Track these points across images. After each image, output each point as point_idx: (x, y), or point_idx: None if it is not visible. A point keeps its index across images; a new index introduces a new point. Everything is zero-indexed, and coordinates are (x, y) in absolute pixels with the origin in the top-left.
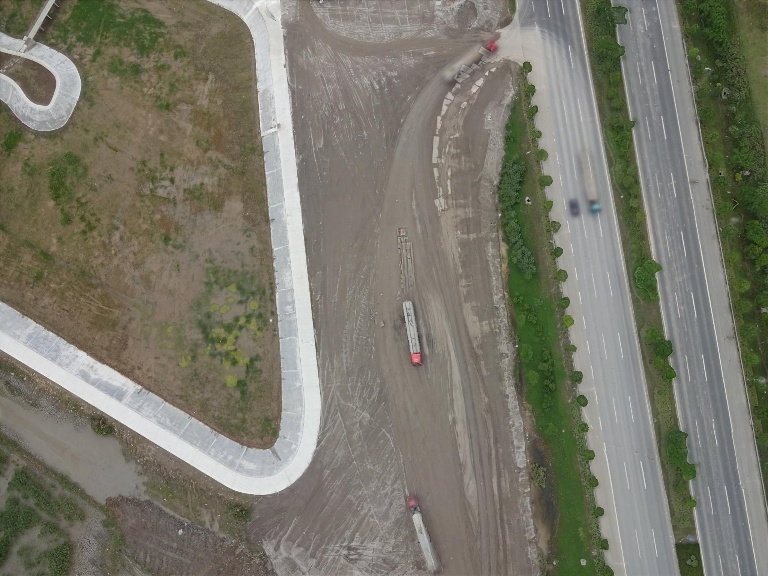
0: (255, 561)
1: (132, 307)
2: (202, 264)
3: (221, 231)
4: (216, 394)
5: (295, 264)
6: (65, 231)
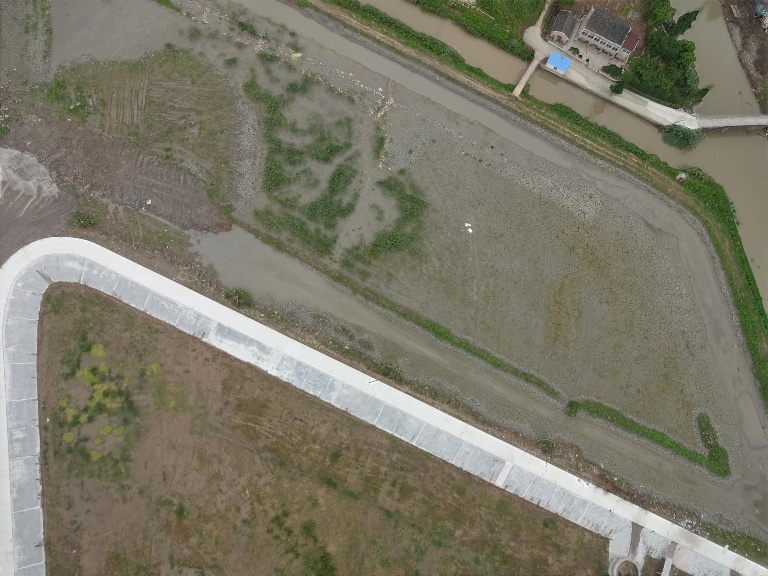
0: (69, 178)
1: (220, 427)
2: (134, 483)
3: (110, 527)
4: (116, 336)
5: (5, 489)
6: (309, 514)
